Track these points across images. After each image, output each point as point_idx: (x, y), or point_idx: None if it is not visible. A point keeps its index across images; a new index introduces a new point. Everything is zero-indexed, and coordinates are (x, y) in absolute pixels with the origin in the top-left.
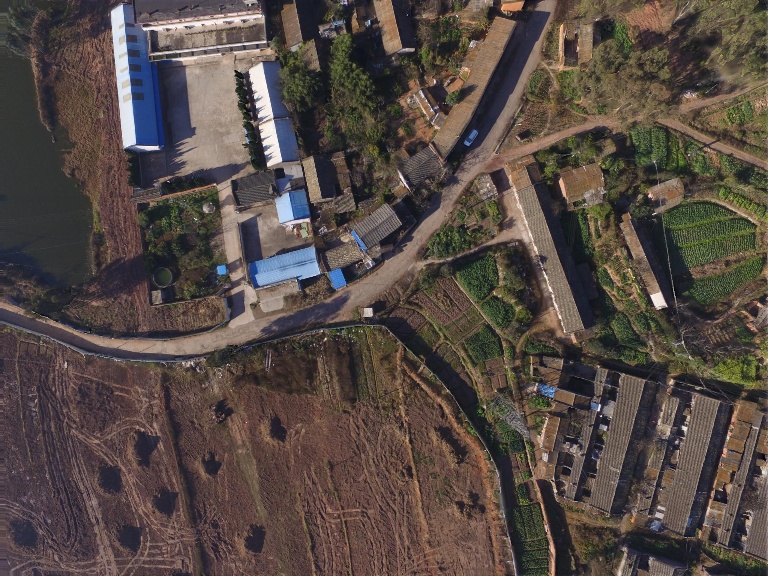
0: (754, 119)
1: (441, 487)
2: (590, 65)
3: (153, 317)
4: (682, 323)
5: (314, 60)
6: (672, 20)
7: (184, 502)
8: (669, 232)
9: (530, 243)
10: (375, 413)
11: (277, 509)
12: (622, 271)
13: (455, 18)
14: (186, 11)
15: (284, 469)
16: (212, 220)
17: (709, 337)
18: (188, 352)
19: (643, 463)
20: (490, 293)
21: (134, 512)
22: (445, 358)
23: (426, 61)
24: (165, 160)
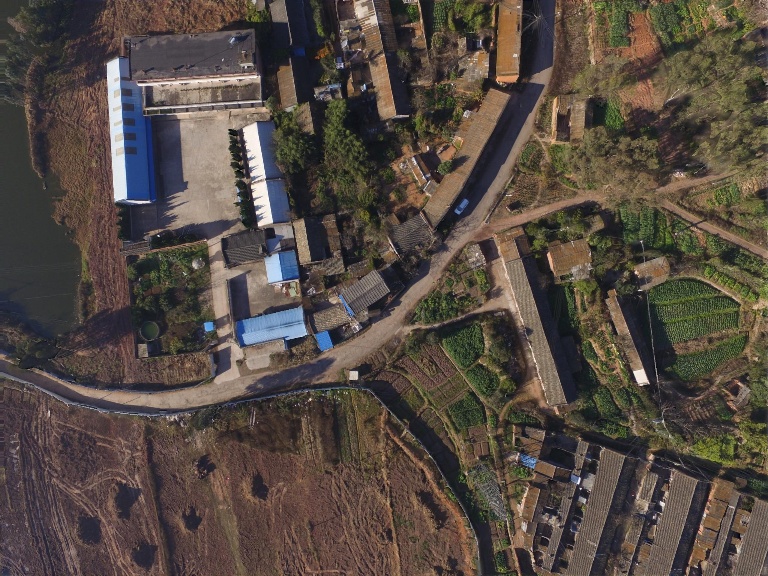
0: (741, 201)
1: (420, 551)
2: (581, 146)
3: (139, 369)
4: (663, 401)
5: (308, 123)
6: (664, 100)
7: (163, 556)
8: (654, 308)
9: (517, 313)
10: (357, 475)
11: (256, 566)
12: (606, 346)
13: (450, 86)
14: (182, 70)
15: (264, 527)
16: (201, 275)
17: (690, 414)
18: (172, 406)
19: (621, 536)
20: (475, 361)
21: (113, 563)
22: (429, 423)
23: (420, 129)
24: (156, 213)
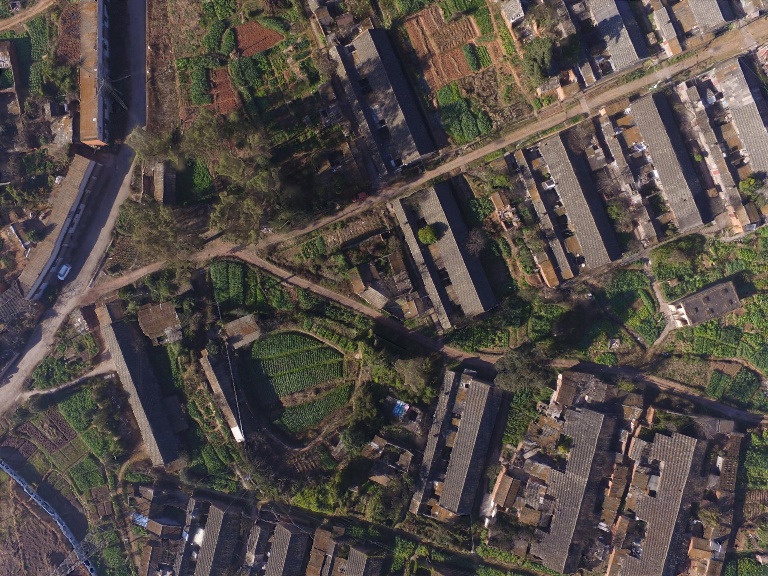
0: (327, 254)
1: None
2: None
3: None
4: (253, 458)
5: None
6: None
7: None
8: (259, 362)
9: None
10: None
11: None
12: (206, 404)
13: None
14: None
15: None
16: None
17: (296, 465)
18: None
19: None
20: None
21: None
22: (55, 486)
23: (14, 197)
24: None
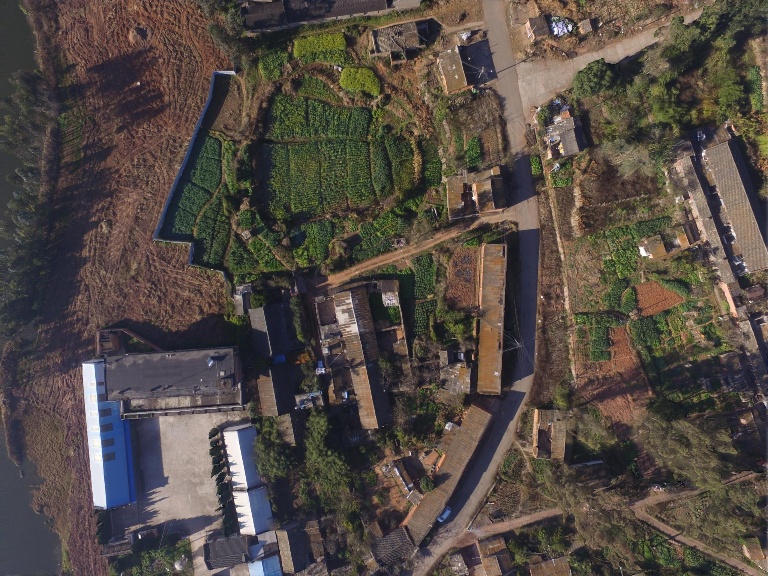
0: None
1: None
2: None
3: None
4: None
5: (290, 434)
6: (643, 419)
7: None
8: None
9: None
10: None
11: None
12: None
13: (432, 391)
14: (159, 391)
15: None
16: (184, 570)
17: None
18: None
19: None
20: None
21: None
22: None
23: (402, 440)
24: (137, 508)
